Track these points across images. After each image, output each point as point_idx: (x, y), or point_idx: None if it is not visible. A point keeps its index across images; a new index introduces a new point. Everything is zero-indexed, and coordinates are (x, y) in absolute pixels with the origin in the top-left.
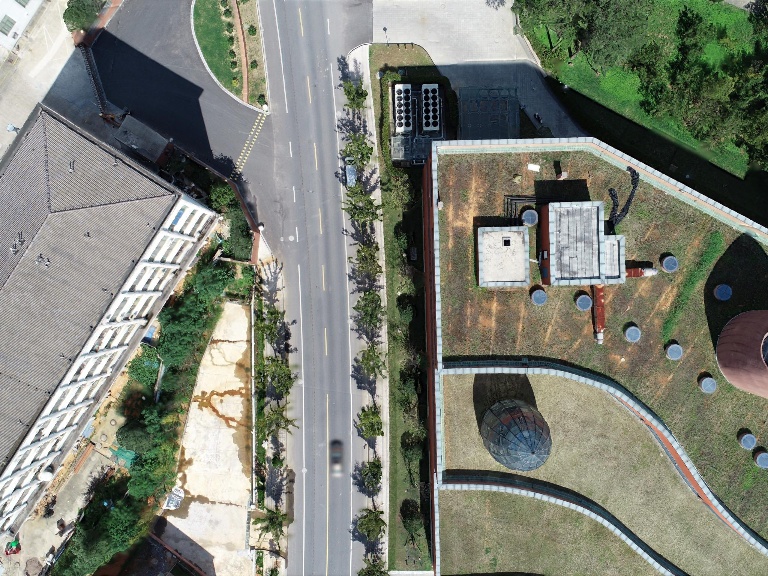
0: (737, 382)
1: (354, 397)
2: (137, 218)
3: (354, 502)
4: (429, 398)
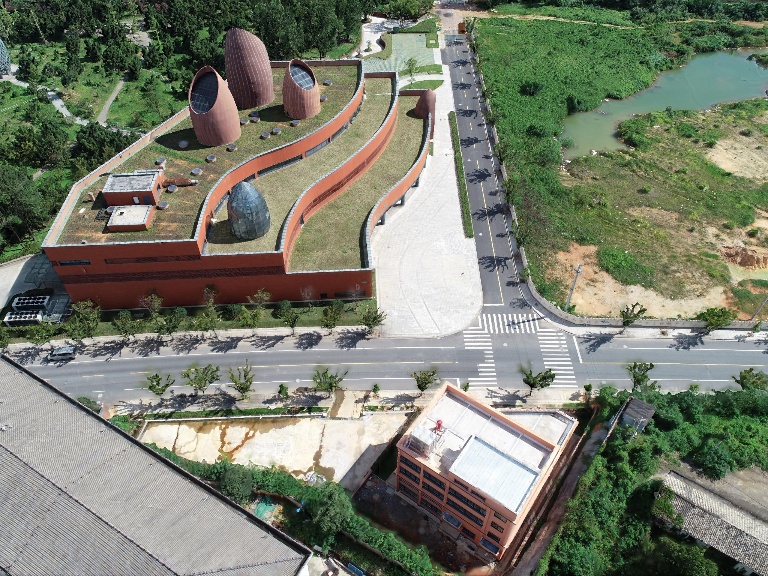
0: (229, 134)
1: (242, 350)
2: (5, 378)
3: (325, 348)
4: (243, 296)
